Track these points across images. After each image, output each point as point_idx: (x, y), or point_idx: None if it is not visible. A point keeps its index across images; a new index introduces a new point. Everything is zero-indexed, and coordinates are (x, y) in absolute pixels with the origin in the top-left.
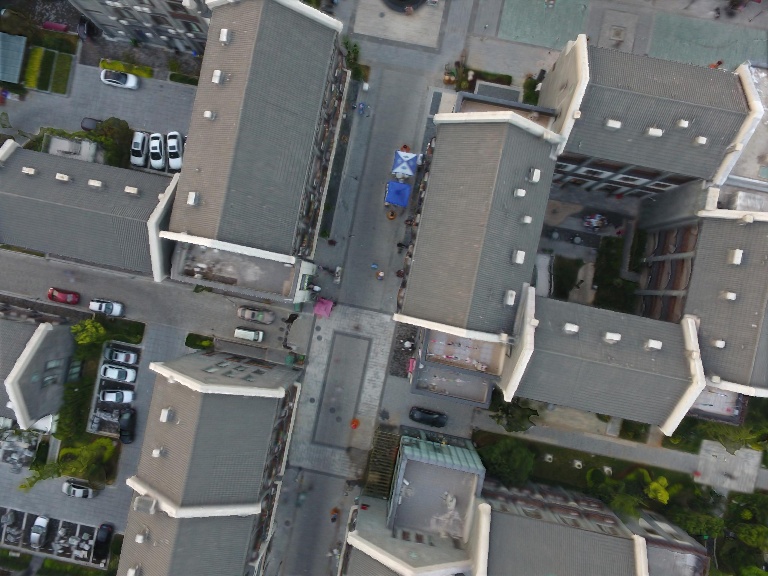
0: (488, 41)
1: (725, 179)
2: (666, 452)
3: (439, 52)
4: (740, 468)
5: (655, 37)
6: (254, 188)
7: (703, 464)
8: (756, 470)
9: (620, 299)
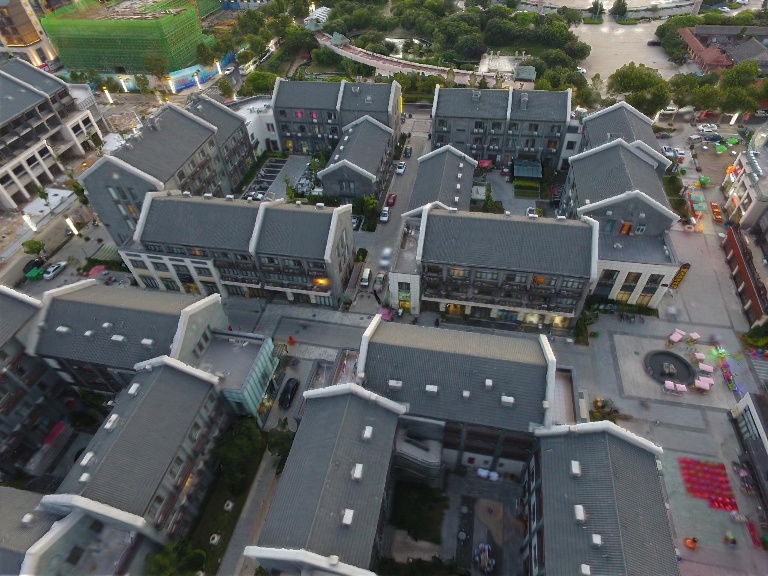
0: (650, 440)
1: None
2: None
3: (622, 397)
4: None
5: None
6: (464, 233)
7: None
8: None
9: None
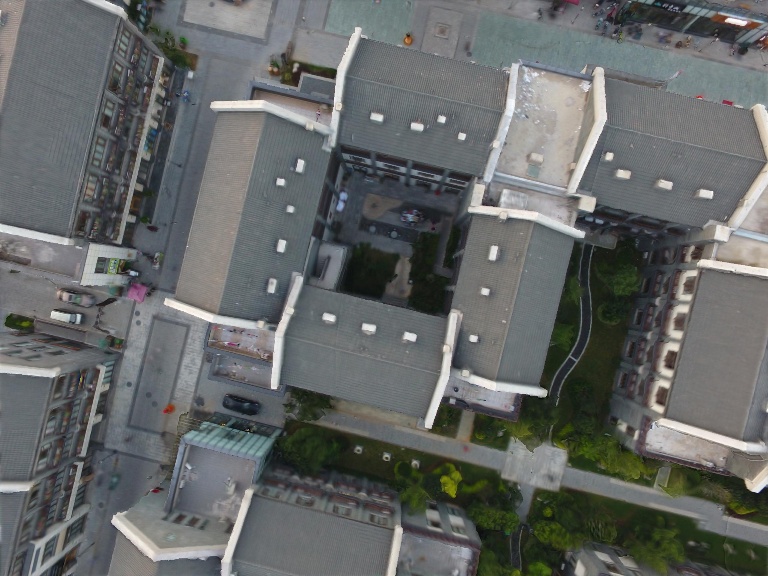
0: (315, 34)
1: (491, 176)
2: (474, 448)
3: (266, 43)
4: (546, 466)
5: (479, 36)
6: (22, 168)
7: (510, 461)
8: (562, 469)
9: (433, 294)
